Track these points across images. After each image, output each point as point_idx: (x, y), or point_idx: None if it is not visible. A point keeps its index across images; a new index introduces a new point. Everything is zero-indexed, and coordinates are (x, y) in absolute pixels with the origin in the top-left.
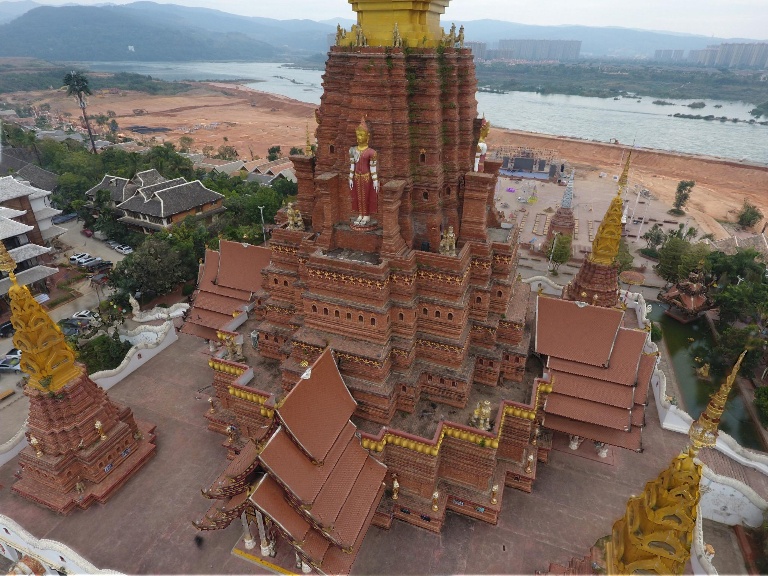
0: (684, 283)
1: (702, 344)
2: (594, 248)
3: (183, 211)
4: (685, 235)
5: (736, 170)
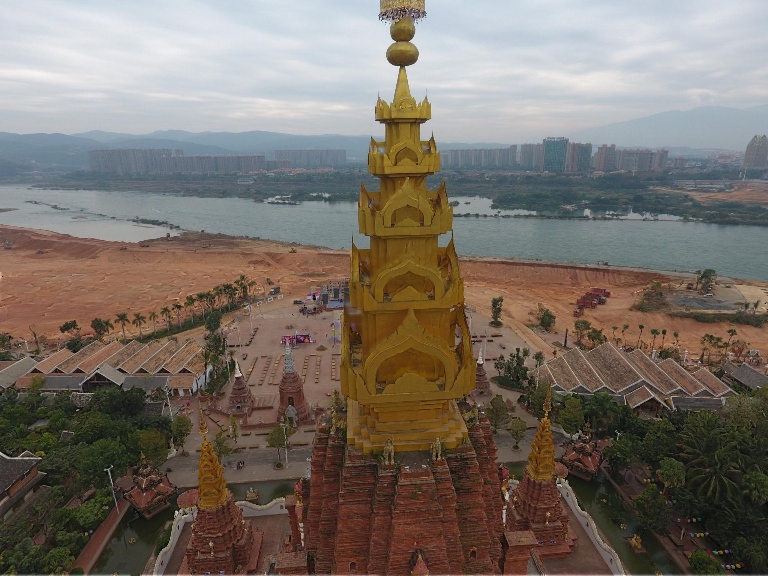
0: (578, 445)
1: (602, 491)
2: (535, 468)
3: None
4: (523, 358)
5: (511, 268)
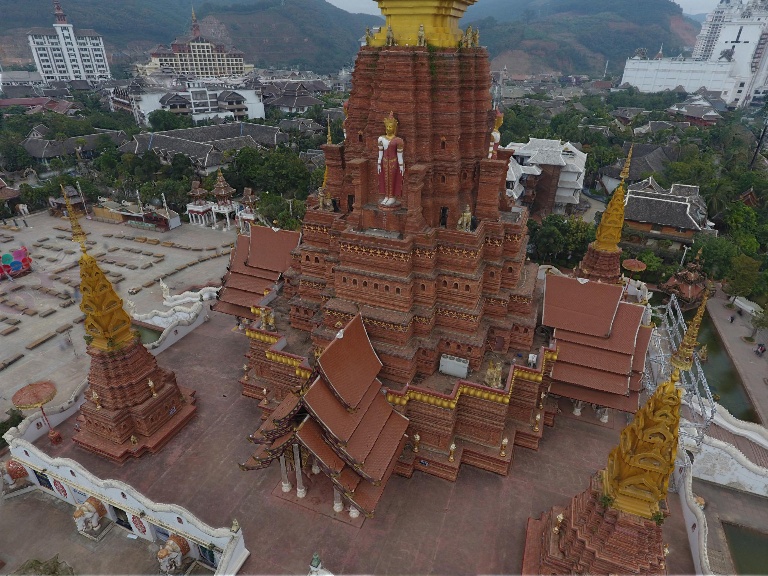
0: None
1: None
2: None
3: (635, 220)
4: None
5: None
